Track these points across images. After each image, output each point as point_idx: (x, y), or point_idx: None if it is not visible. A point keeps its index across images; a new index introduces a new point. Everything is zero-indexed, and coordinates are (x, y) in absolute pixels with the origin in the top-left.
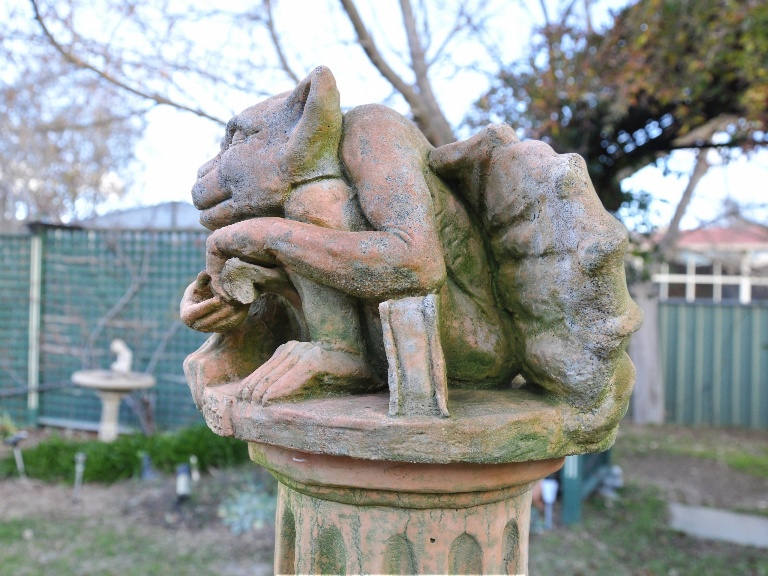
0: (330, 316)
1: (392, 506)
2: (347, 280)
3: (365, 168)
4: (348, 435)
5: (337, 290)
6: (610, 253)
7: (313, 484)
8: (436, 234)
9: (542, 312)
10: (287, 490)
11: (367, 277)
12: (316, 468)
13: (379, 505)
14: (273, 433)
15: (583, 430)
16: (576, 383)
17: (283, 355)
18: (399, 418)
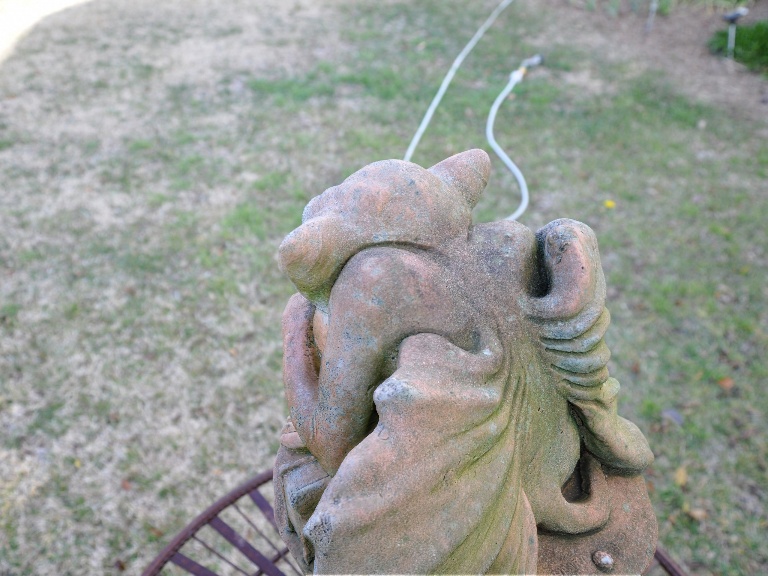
0: None
1: None
2: None
3: (326, 337)
4: None
5: None
6: None
7: None
8: (346, 437)
9: None
10: None
11: None
12: None
13: None
14: None
15: None
16: None
17: None
18: (289, 535)
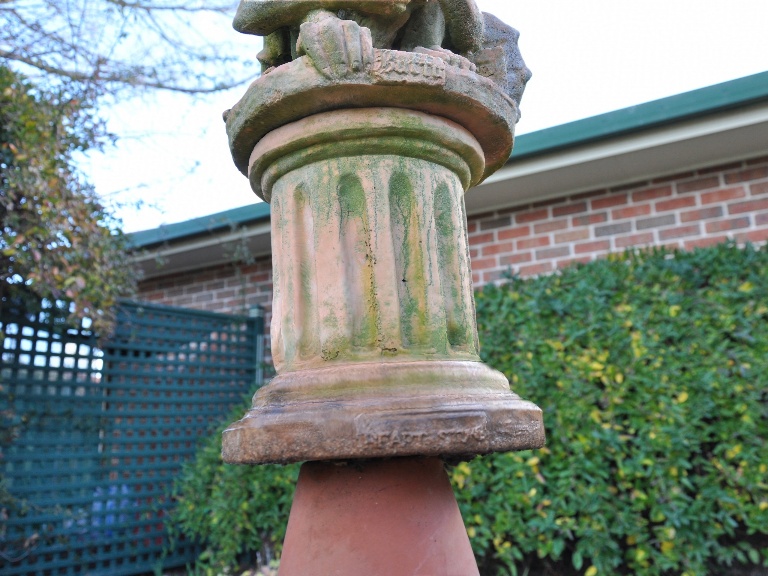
0: None
1: (460, 177)
2: (473, 25)
3: None
4: None
5: None
6: None
7: None
8: None
9: None
10: (399, 158)
11: None
12: None
13: (458, 174)
14: (478, 91)
15: None
16: None
17: None
18: None
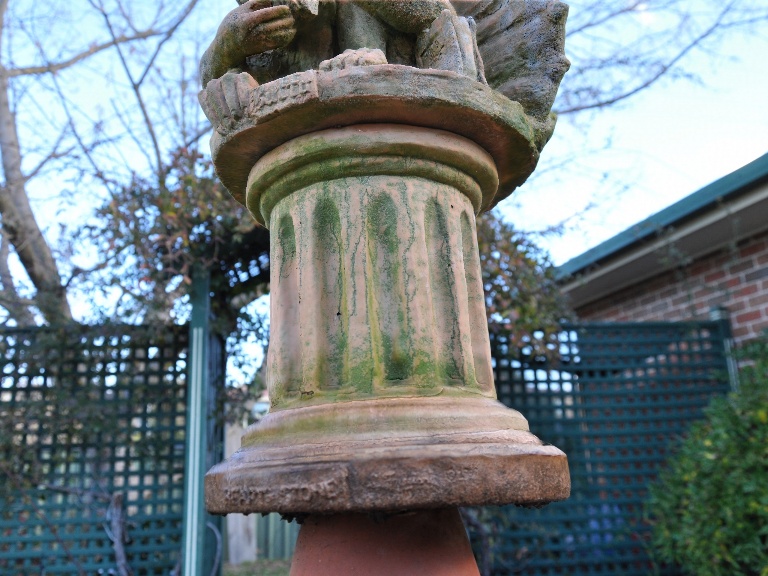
0: (373, 41)
1: (427, 177)
2: (406, 3)
3: None
4: (437, 82)
5: (380, 23)
6: (566, 9)
7: (375, 151)
8: None
9: (504, 68)
10: (322, 185)
11: (420, 3)
12: (384, 133)
13: (418, 176)
14: (370, 85)
15: (541, 131)
16: (540, 96)
17: (350, 52)
18: None
